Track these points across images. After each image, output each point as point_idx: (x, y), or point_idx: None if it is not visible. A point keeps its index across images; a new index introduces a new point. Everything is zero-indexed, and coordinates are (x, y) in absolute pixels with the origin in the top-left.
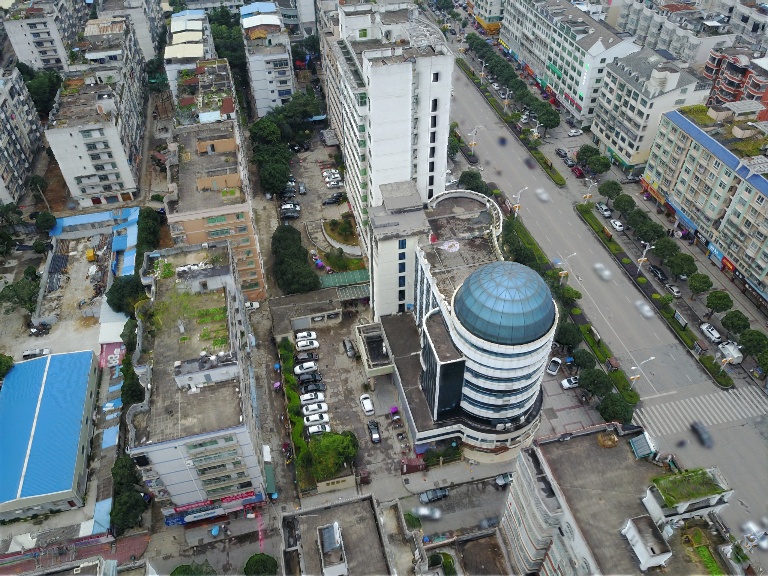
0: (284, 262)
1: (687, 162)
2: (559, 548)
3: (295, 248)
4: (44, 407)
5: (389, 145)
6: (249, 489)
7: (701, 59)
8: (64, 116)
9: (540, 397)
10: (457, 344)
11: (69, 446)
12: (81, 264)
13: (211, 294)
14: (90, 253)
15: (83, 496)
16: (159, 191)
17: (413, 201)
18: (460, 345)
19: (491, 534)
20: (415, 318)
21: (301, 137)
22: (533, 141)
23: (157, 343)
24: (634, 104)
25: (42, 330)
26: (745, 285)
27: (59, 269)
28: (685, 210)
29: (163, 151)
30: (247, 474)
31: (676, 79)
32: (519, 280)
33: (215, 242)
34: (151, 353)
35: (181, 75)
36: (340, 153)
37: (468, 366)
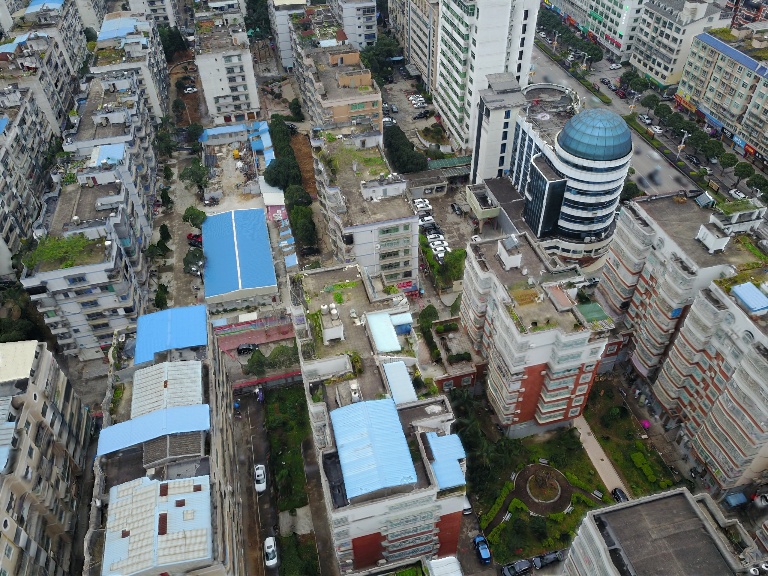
0: (400, 149)
1: (715, 72)
2: (652, 261)
3: (406, 140)
4: (240, 240)
5: (490, 47)
6: (409, 279)
7: (722, 2)
8: (206, 47)
9: (614, 224)
10: (561, 169)
11: (266, 262)
12: (228, 161)
13: (368, 150)
14: (236, 152)
15: (279, 296)
16: (279, 110)
17: (513, 85)
18: (563, 169)
19: (591, 294)
20: (511, 180)
21: (385, 73)
22: (582, 71)
23: (338, 177)
24: (669, 32)
25: (213, 202)
26: (764, 162)
27: (213, 164)
28: (713, 113)
29: (270, 85)
30: (410, 264)
31: (704, 9)
32: (608, 115)
33: (361, 120)
34: (336, 182)
35: (291, 18)
36: (421, 83)
37: (569, 185)
